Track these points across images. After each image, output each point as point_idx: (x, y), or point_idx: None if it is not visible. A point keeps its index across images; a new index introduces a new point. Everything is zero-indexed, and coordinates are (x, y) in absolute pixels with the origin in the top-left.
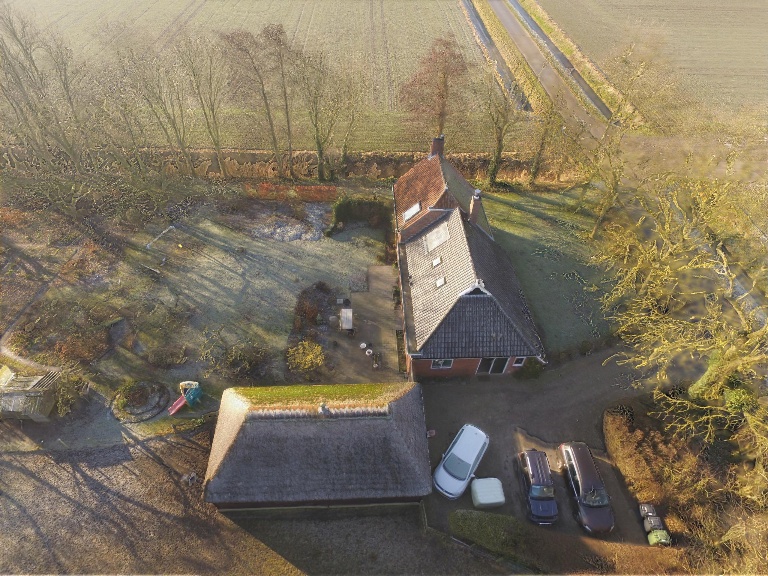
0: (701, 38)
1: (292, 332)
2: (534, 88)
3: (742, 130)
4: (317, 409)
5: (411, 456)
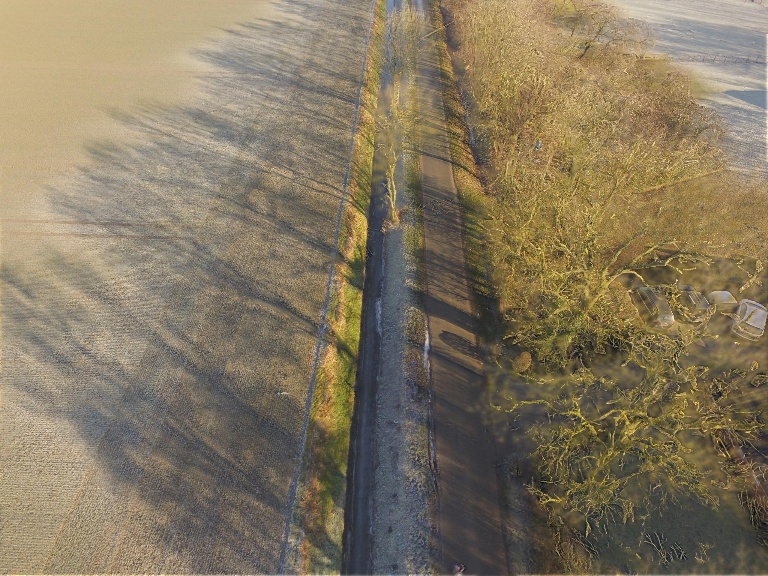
0: None
1: None
2: None
3: None
4: None
5: None
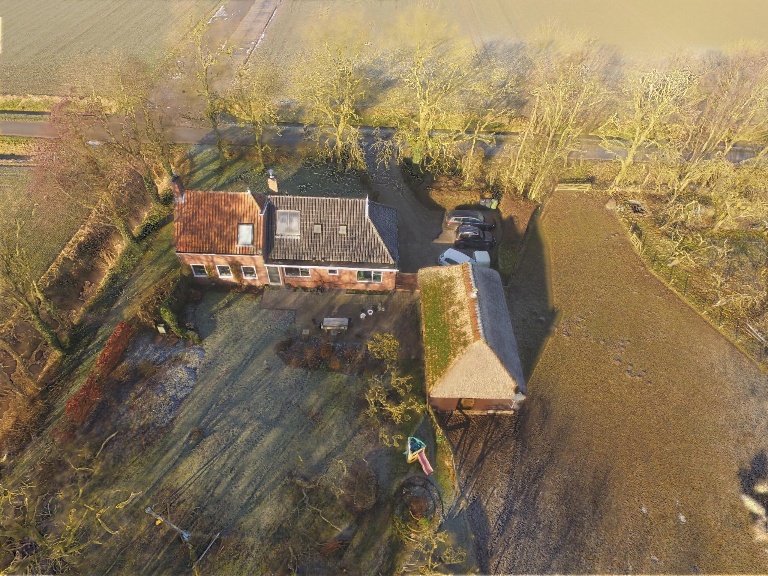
0: None
1: (339, 372)
2: None
3: (163, 65)
4: (474, 298)
5: (487, 268)
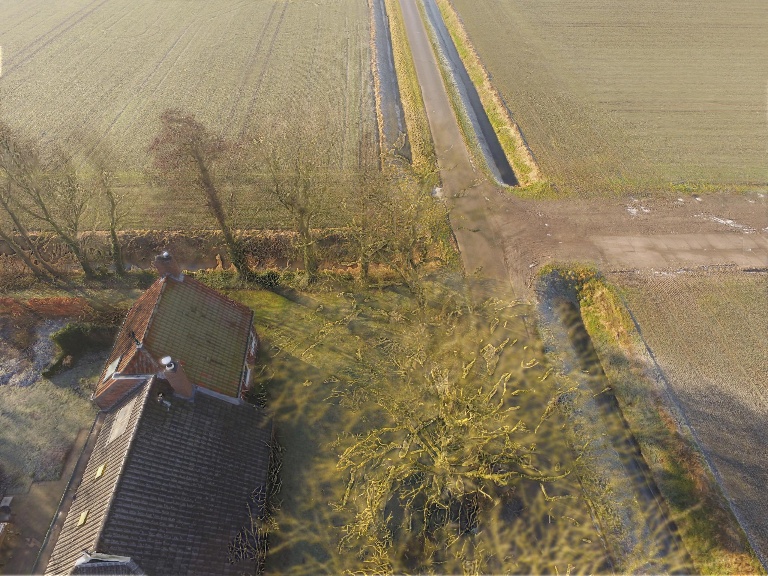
0: (634, 62)
1: None
2: (419, 132)
3: (654, 189)
4: None
5: None
